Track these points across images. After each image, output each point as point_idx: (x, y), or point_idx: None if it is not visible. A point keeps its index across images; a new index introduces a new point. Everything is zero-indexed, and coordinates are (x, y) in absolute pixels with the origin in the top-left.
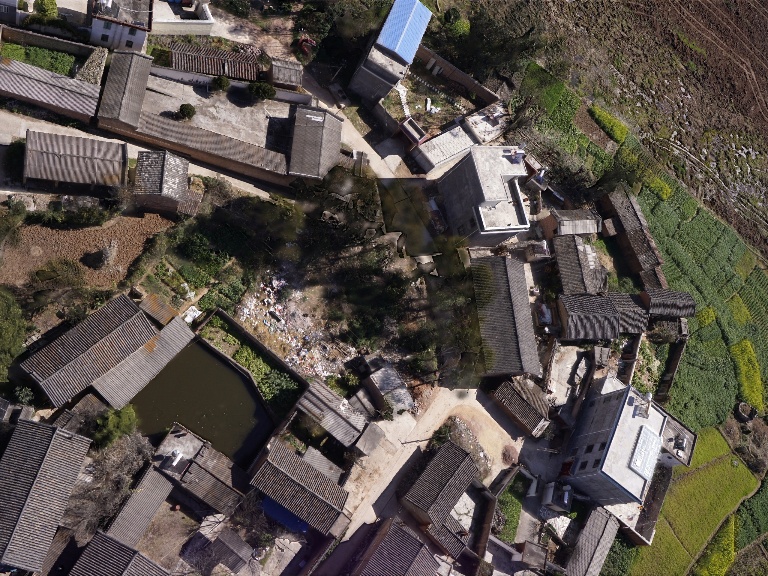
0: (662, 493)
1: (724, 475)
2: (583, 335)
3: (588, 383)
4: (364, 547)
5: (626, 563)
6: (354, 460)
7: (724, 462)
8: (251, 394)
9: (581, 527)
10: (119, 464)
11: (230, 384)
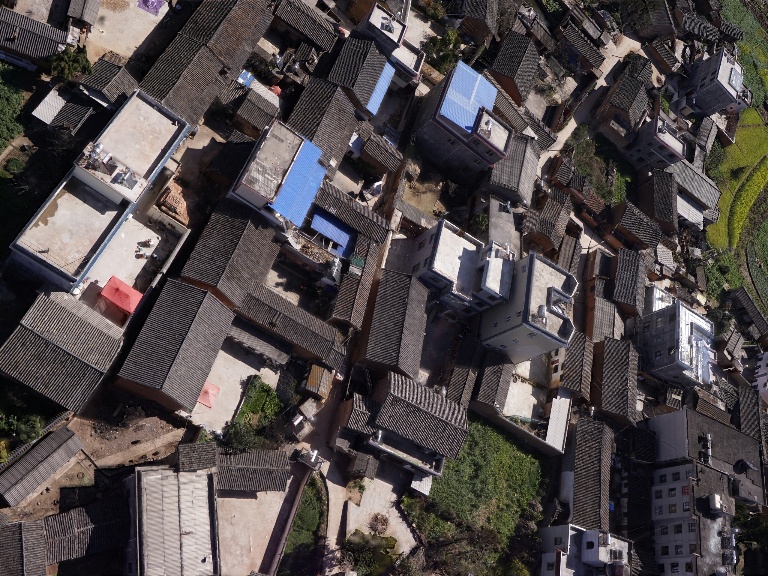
0: (735, 124)
1: (762, 134)
2: (690, 29)
3: (693, 58)
4: (604, 95)
5: (720, 154)
6: (599, 47)
7: (761, 128)
8: (541, 10)
9: (698, 127)
10: (509, 7)
11: (531, 2)
